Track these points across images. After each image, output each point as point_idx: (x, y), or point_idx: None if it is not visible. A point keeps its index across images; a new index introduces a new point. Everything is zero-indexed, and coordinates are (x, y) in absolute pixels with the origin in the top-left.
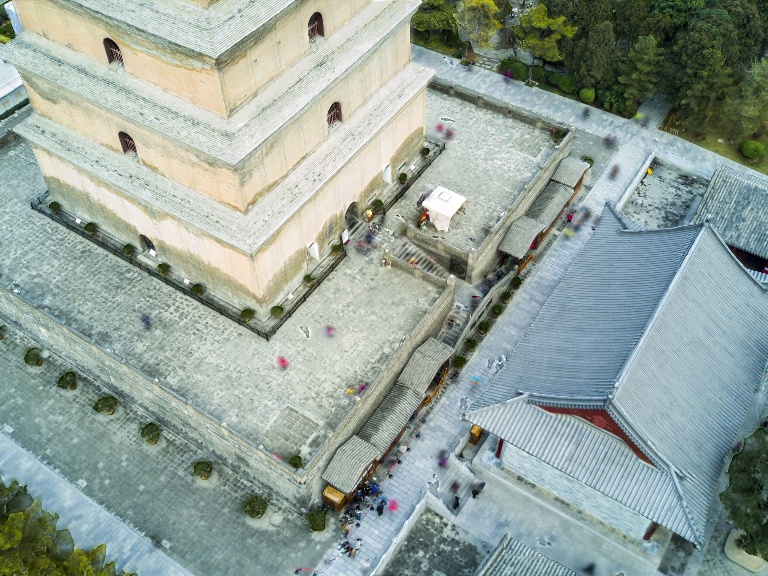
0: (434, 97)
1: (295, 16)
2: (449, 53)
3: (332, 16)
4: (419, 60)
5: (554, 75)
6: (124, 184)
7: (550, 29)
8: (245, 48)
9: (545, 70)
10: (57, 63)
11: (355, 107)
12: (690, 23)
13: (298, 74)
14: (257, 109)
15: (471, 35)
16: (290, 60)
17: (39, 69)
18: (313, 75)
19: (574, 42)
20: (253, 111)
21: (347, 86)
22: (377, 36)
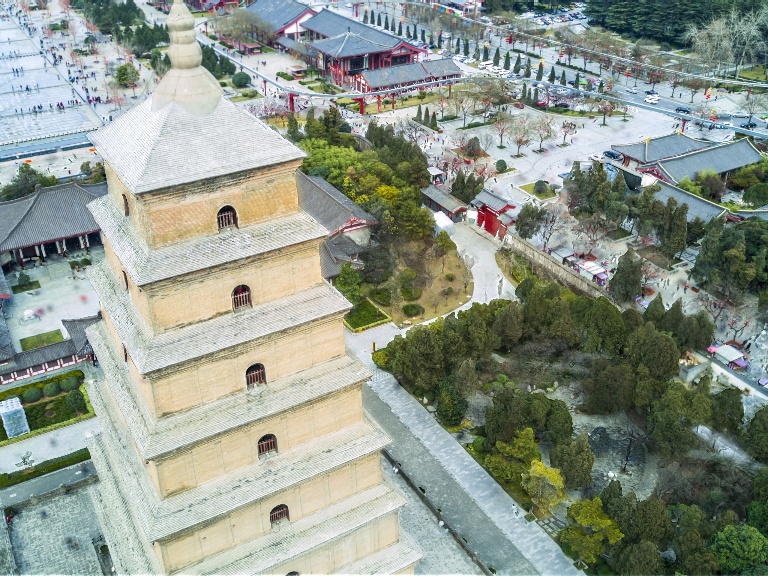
0: (459, 556)
1: (255, 508)
2: (521, 501)
3: (301, 506)
4: (489, 499)
5: (602, 567)
6: (120, 574)
7: (592, 529)
8: (193, 530)
9: (598, 557)
10: (108, 468)
11: (319, 575)
12: (741, 575)
13: (251, 549)
14: (198, 573)
15: (532, 499)
16: (246, 537)
17: (98, 466)
18: (264, 553)
19: (626, 544)
20: (193, 574)
21: (309, 560)
22: (345, 527)
